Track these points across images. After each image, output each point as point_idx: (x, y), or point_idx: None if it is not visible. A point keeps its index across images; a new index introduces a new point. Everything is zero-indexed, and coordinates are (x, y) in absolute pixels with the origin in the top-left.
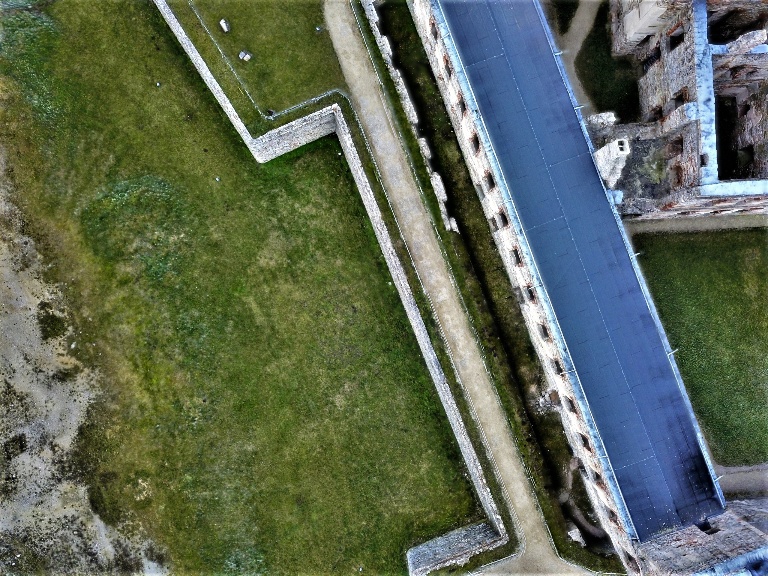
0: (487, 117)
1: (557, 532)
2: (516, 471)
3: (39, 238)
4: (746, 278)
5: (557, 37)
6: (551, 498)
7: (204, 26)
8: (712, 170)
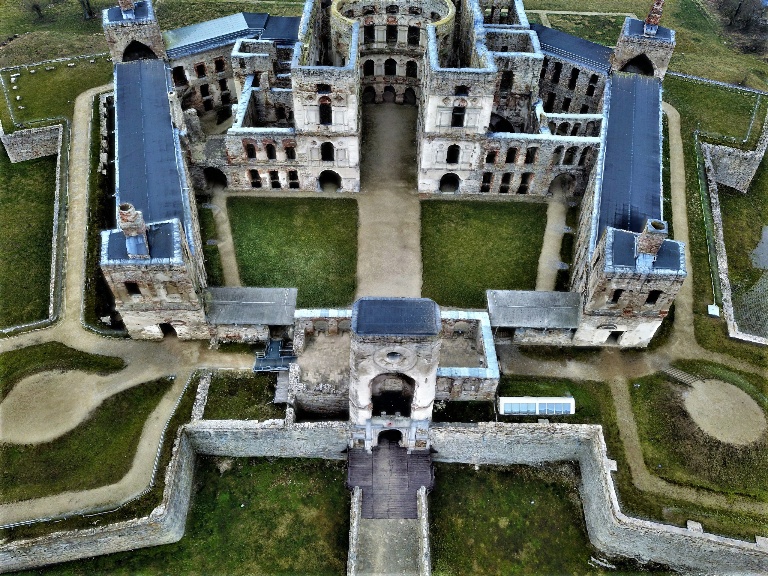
0: (120, 100)
1: (92, 315)
2: (79, 280)
3: None
4: (296, 217)
5: (214, 125)
6: (97, 296)
7: (5, 95)
8: (238, 124)
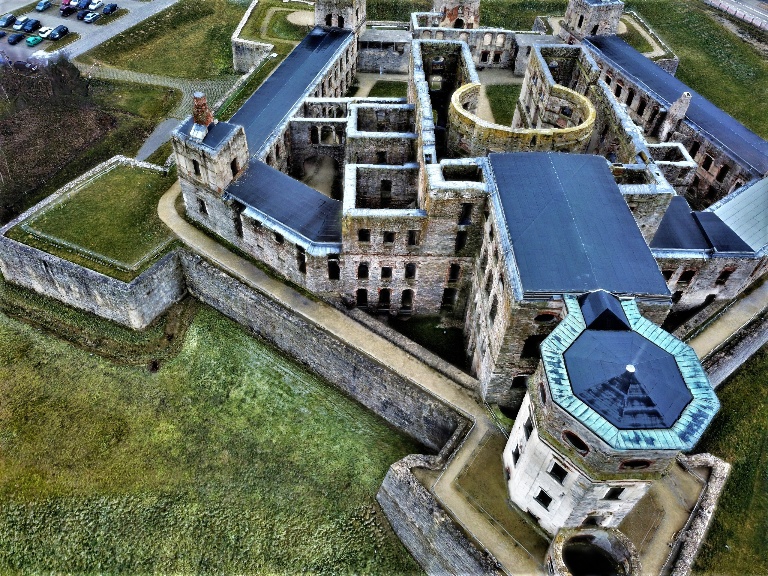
0: None
1: None
2: None
3: None
4: None
5: None
6: None
7: None
8: None
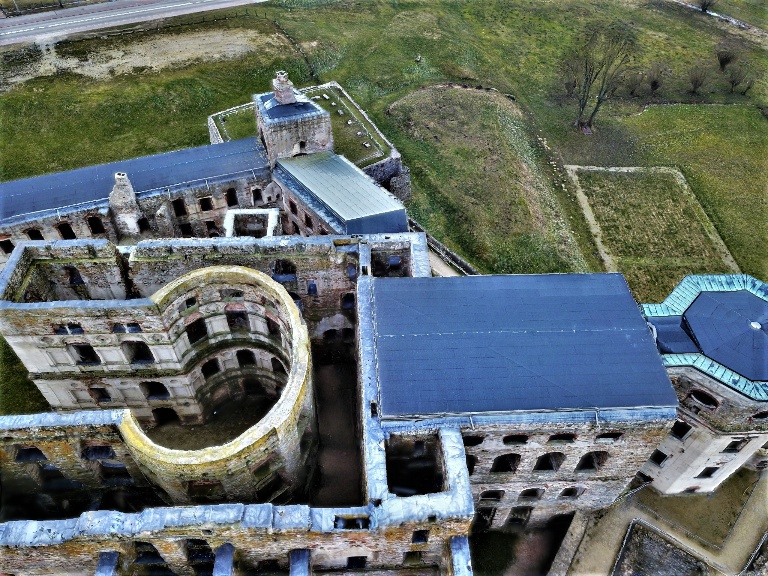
0: (173, 153)
1: None
2: None
3: (186, 68)
4: None
5: None
6: None
7: None
8: None
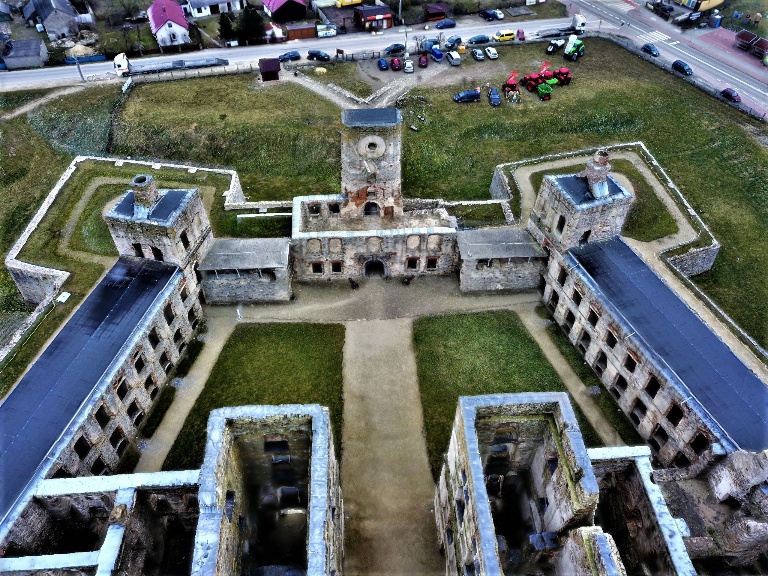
0: None
1: None
2: None
3: None
4: None
5: None
6: None
7: None
8: (645, 469)
